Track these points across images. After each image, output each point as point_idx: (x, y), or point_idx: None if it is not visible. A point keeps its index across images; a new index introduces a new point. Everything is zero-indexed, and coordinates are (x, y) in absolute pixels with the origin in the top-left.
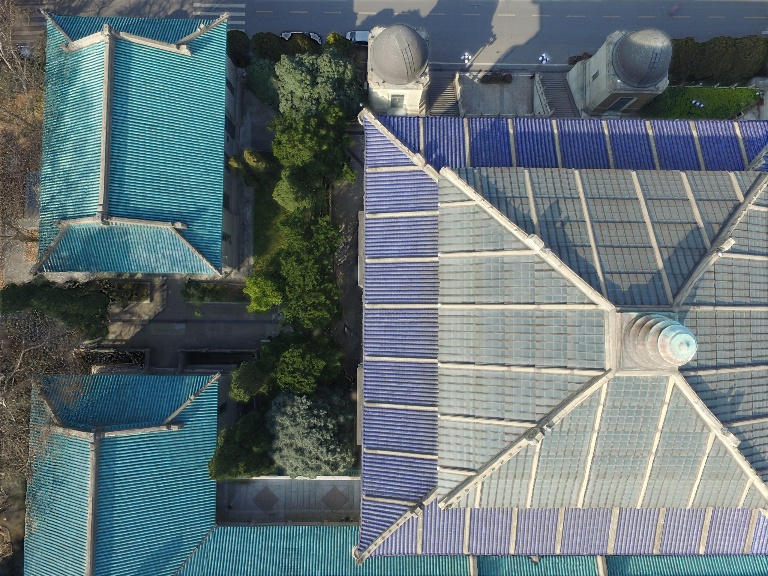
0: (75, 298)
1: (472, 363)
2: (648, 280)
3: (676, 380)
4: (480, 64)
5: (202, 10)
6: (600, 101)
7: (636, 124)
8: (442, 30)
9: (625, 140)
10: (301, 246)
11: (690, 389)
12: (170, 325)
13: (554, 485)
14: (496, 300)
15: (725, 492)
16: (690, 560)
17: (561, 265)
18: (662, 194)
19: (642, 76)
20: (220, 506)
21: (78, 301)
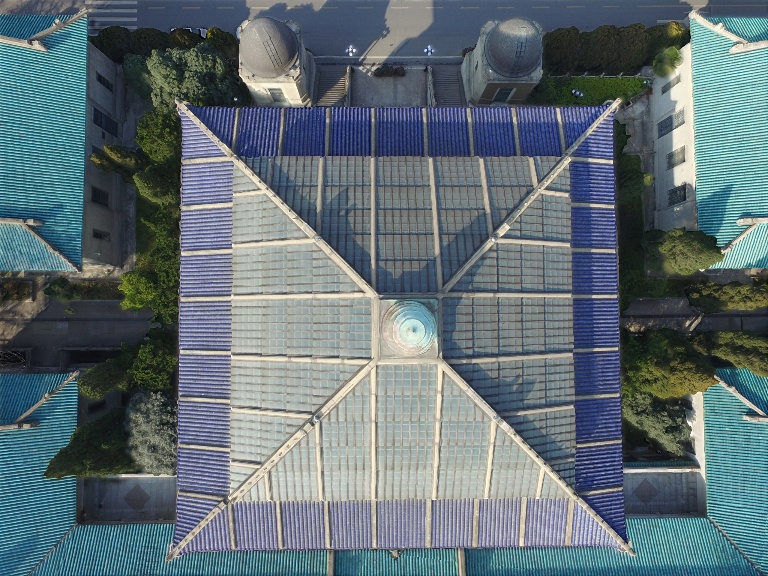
0: None
1: (259, 354)
2: (422, 267)
3: (442, 368)
4: (373, 57)
5: (94, 7)
6: (481, 92)
7: (457, 111)
8: (335, 24)
9: (443, 128)
10: (166, 242)
11: (457, 377)
12: (53, 324)
13: (344, 477)
14: (280, 290)
15: (520, 482)
16: (554, 553)
17: (332, 253)
18: (456, 181)
19: (511, 66)
20: (90, 505)
21: None
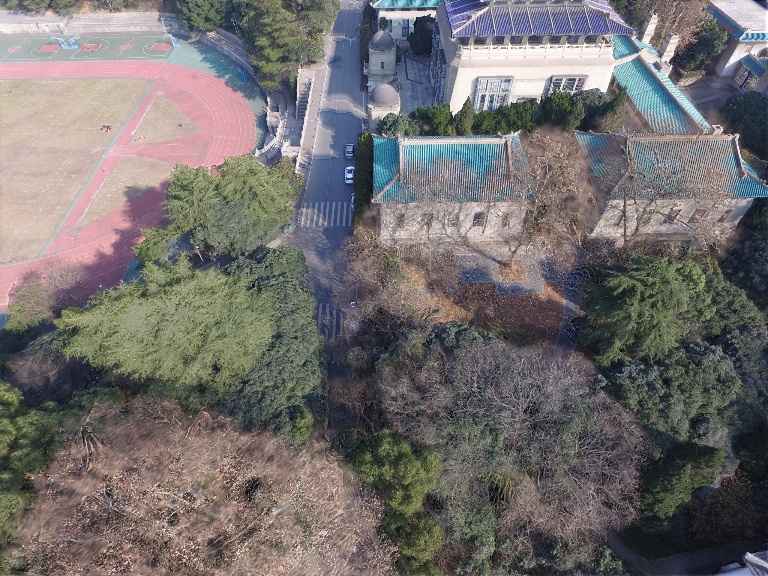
0: None
1: None
2: None
3: None
4: (363, 116)
5: (324, 222)
6: None
7: None
8: (344, 128)
9: None
10: (493, 119)
11: None
12: None
13: None
14: None
15: None
16: None
17: None
18: None
19: (392, 40)
20: None
21: None
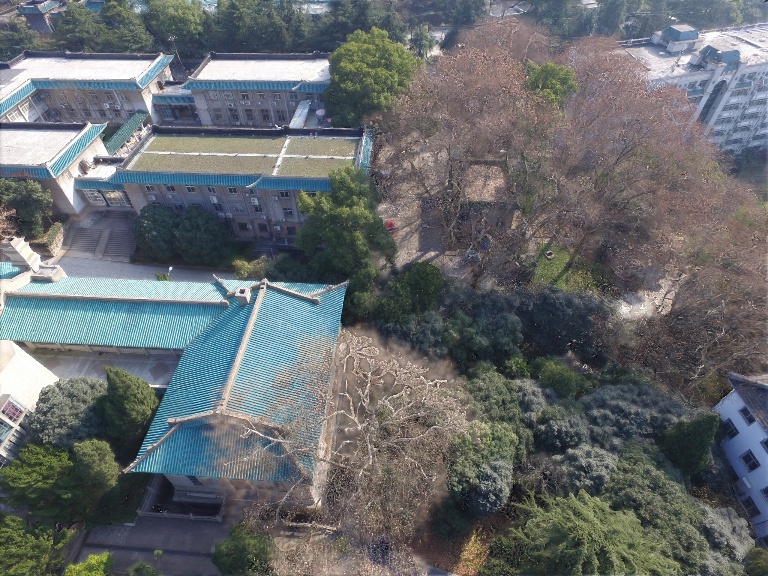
0: (217, 561)
1: None
2: None
3: None
4: None
5: None
6: None
7: None
8: None
9: None
10: None
11: None
12: None
13: None
14: None
15: None
16: None
17: None
18: None
19: None
20: None
21: (214, 556)
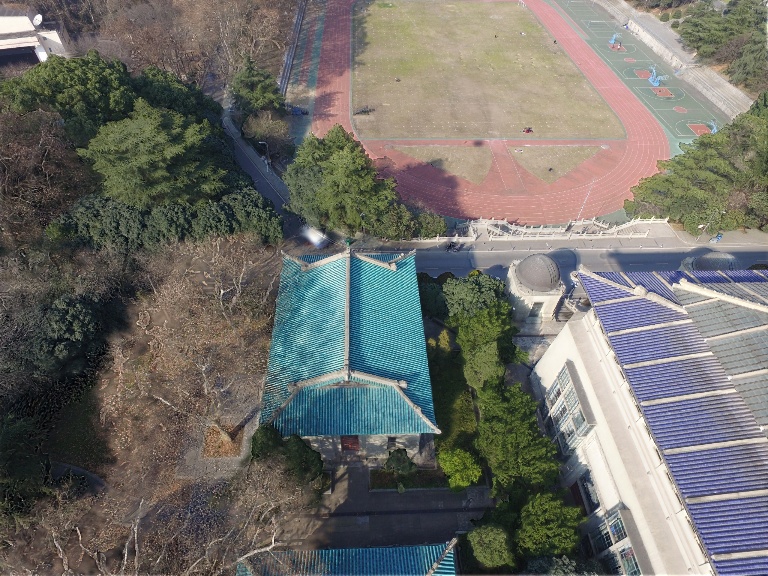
0: None
1: None
2: None
3: None
4: (578, 294)
5: None
6: None
7: None
8: None
9: None
10: (503, 408)
11: None
12: (352, 519)
13: None
14: None
15: None
16: None
17: None
18: None
19: None
20: None
21: None
